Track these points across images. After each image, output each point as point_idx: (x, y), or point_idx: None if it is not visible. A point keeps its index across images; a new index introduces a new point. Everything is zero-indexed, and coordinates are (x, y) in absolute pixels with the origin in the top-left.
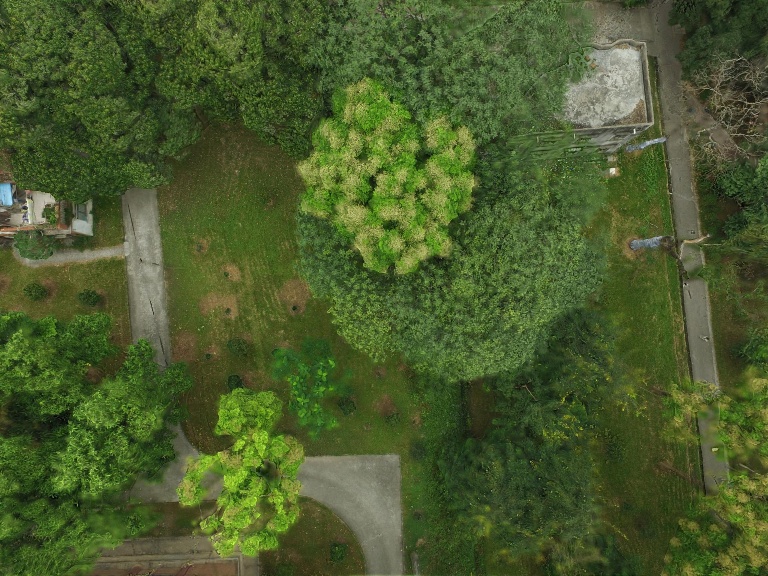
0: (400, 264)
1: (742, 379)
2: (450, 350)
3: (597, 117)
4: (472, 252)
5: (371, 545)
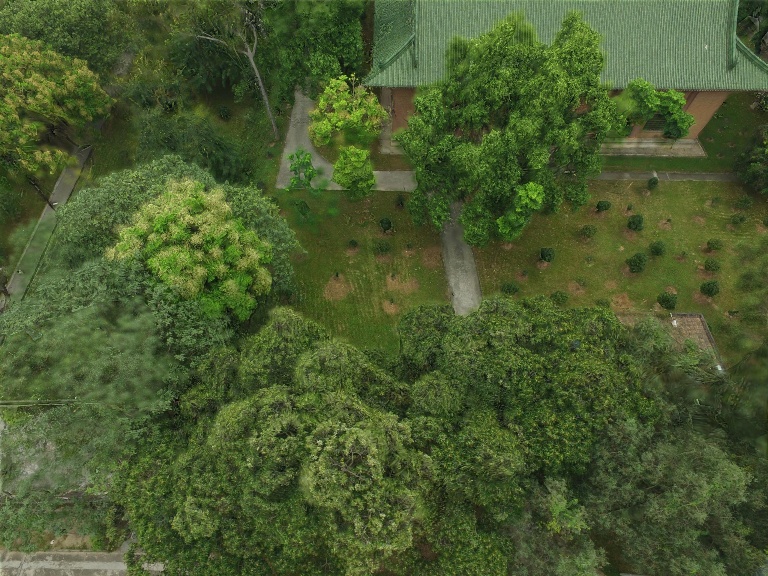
0: None
1: (8, 244)
2: (190, 168)
3: (7, 418)
4: (145, 199)
5: (305, 145)
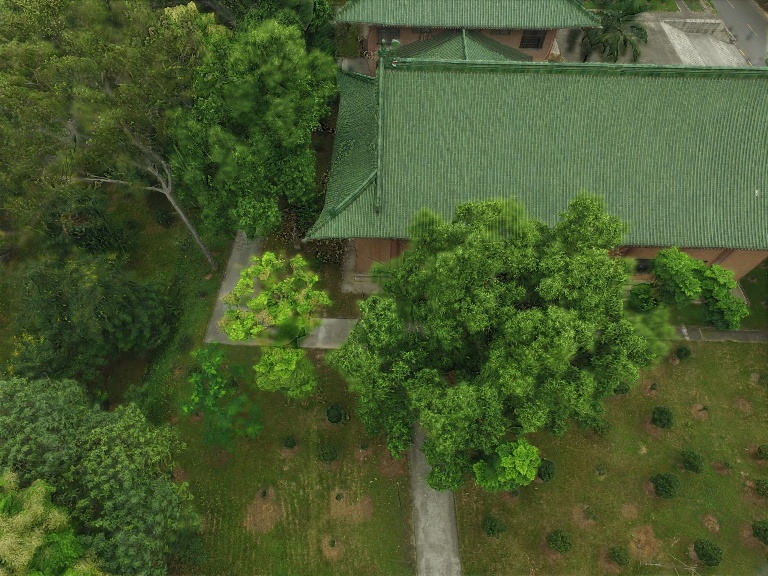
0: (3, 483)
1: None
2: None
3: None
4: None
5: None
